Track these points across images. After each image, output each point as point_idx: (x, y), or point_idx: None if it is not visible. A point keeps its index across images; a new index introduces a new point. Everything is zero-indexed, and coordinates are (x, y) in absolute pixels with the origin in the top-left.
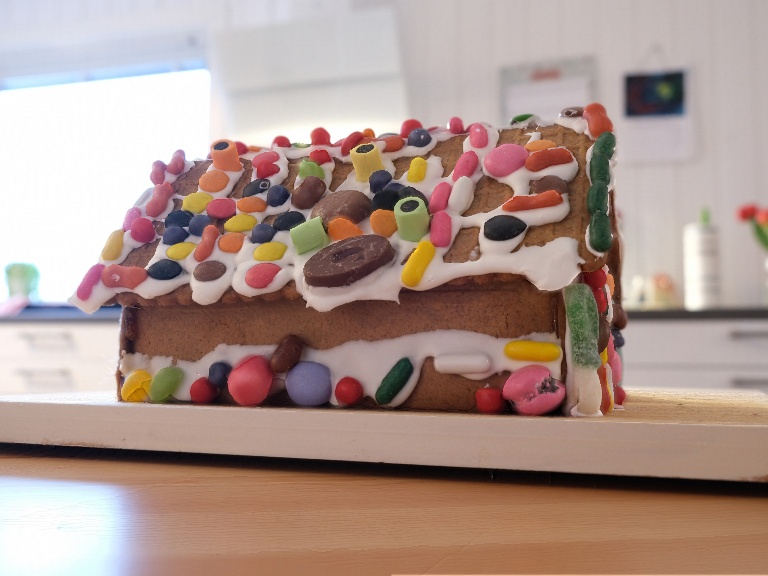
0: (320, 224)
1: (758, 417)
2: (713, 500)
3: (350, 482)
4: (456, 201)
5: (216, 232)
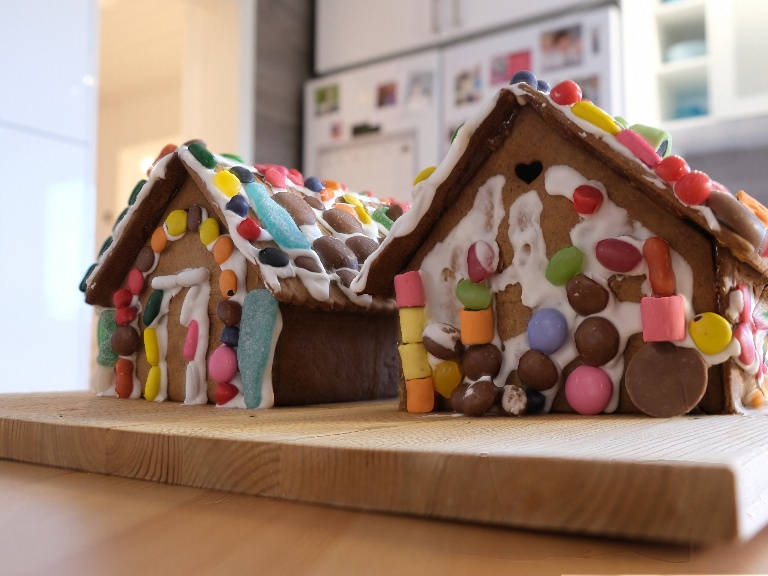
0: None
1: (43, 406)
2: None
3: None
4: None
5: None
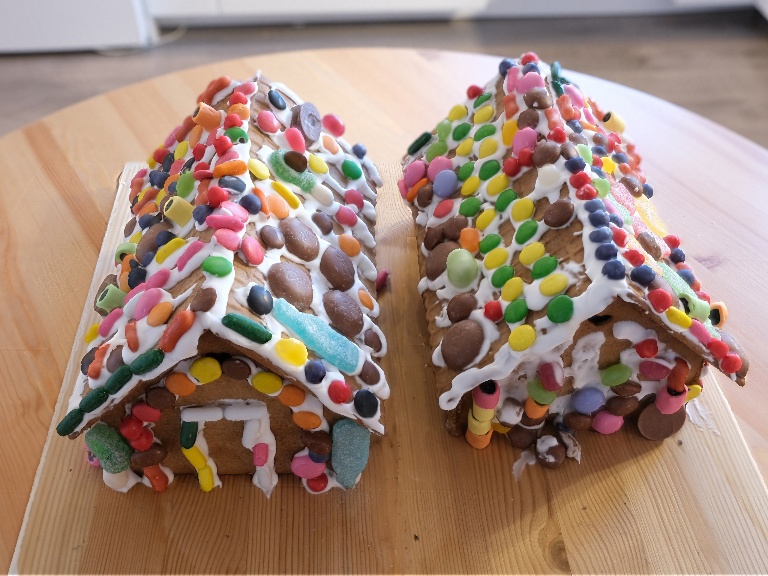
0: (116, 257)
1: None
2: (7, 570)
3: (48, 408)
4: (124, 310)
5: (148, 198)
